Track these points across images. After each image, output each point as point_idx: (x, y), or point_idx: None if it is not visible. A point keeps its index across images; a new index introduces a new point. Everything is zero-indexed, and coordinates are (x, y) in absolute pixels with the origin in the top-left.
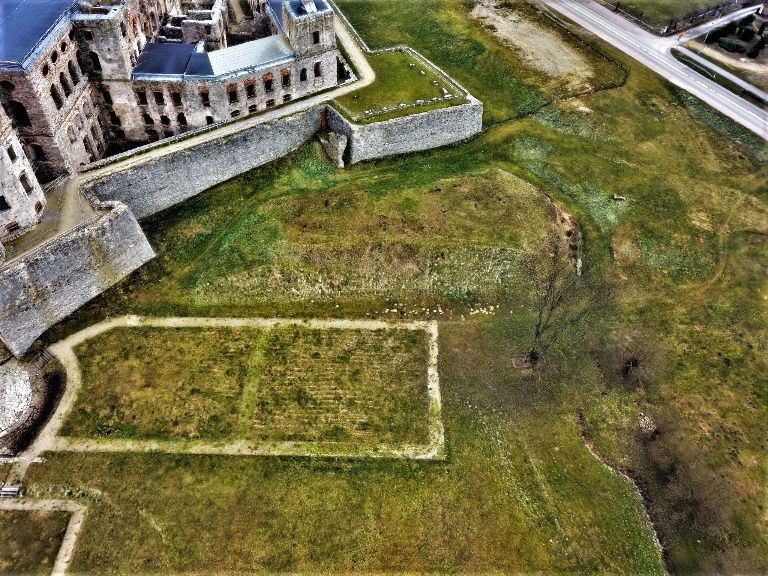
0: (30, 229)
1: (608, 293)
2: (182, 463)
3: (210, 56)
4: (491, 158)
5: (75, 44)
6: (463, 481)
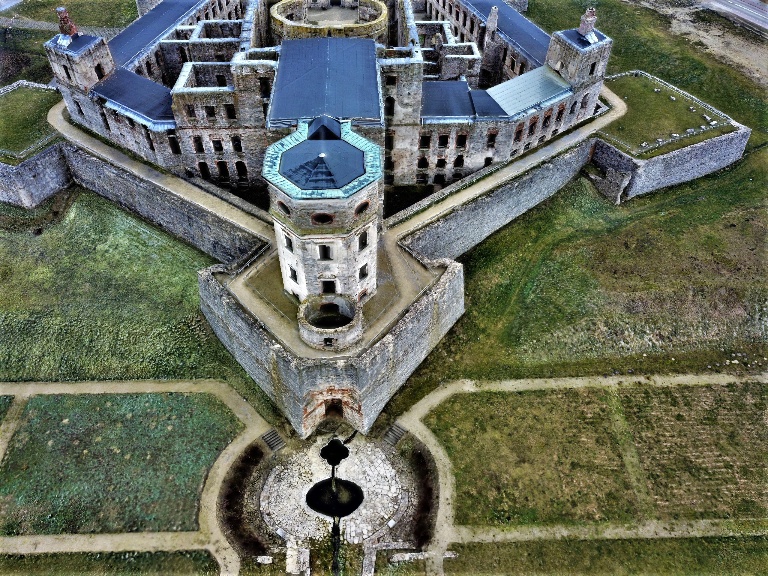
0: (373, 295)
1: None
2: (604, 551)
3: (491, 94)
4: (760, 186)
5: None
6: None
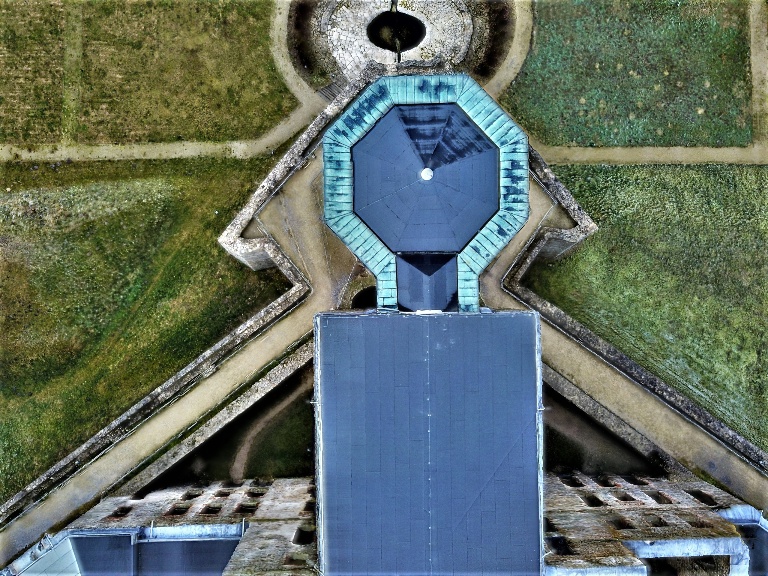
0: None
1: None
2: None
3: None
4: None
5: None
6: None
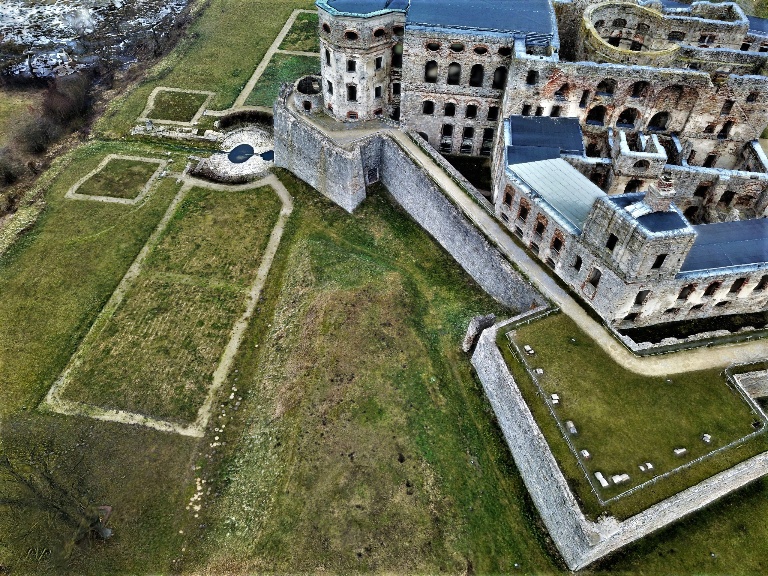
0: (336, 119)
1: (0, 535)
2: (138, 242)
3: (553, 160)
4: None
5: (504, 61)
6: (8, 419)
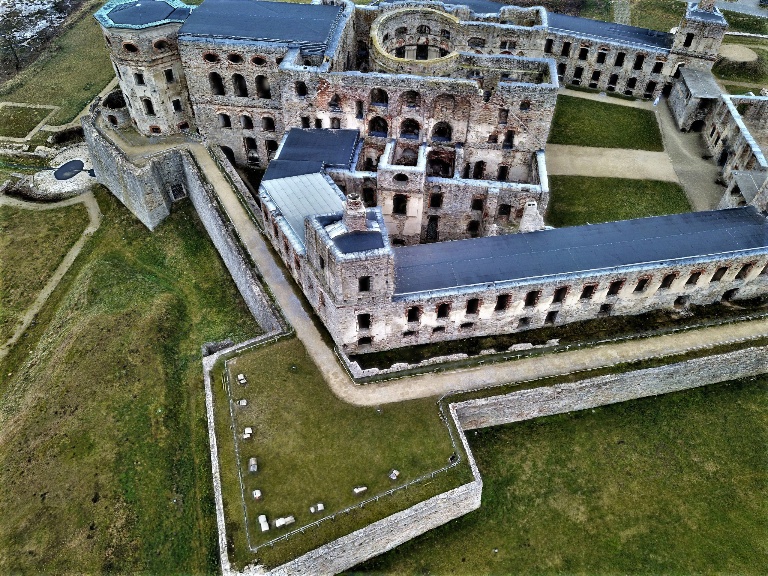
0: None
1: None
2: None
3: (310, 175)
4: None
5: None
6: None
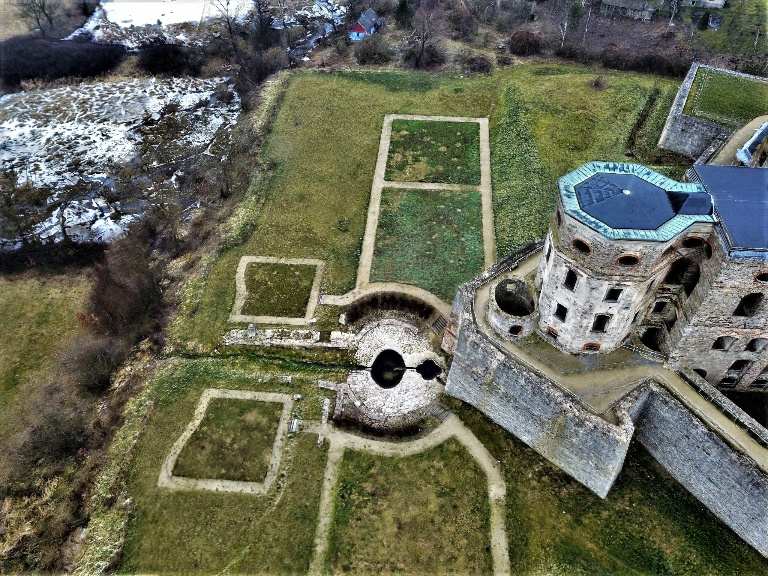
0: (562, 349)
1: None
2: None
3: None
4: None
5: None
6: None
